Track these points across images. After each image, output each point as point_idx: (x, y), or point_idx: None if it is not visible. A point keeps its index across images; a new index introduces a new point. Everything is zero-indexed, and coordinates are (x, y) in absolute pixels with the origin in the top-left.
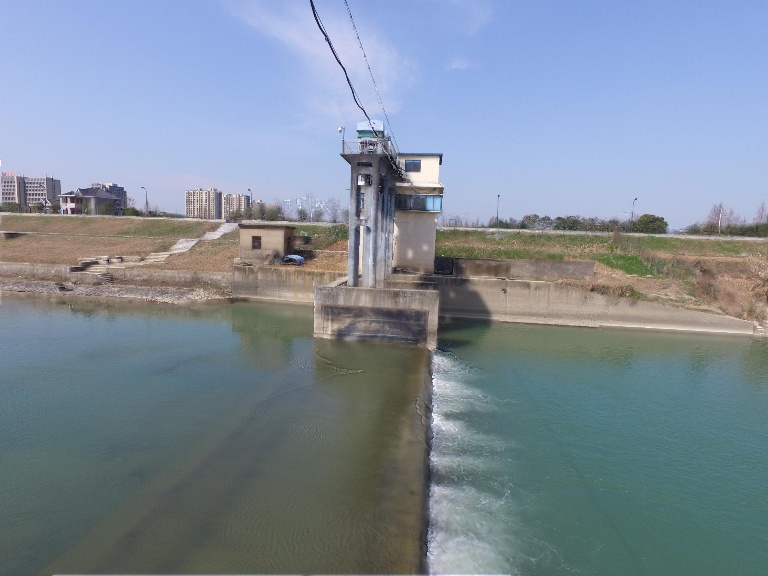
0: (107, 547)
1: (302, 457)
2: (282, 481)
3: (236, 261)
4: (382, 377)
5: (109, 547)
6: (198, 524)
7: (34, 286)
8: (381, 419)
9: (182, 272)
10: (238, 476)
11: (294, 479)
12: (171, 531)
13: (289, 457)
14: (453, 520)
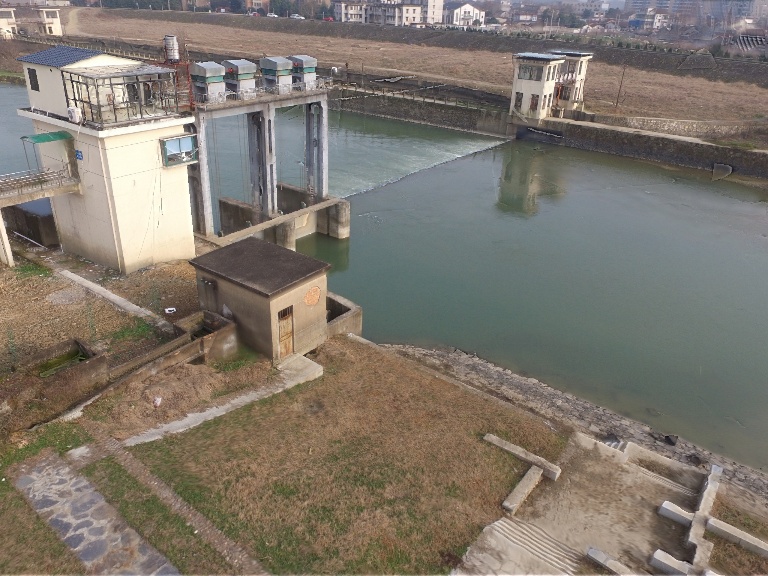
0: (460, 189)
1: (413, 193)
2: (422, 190)
3: (320, 370)
4: (351, 209)
5: (459, 189)
6: (443, 189)
7: (759, 483)
8: (379, 195)
9: (445, 376)
10: (432, 193)
11: (419, 190)
12: (448, 189)
13: (417, 193)
14: (389, 182)
